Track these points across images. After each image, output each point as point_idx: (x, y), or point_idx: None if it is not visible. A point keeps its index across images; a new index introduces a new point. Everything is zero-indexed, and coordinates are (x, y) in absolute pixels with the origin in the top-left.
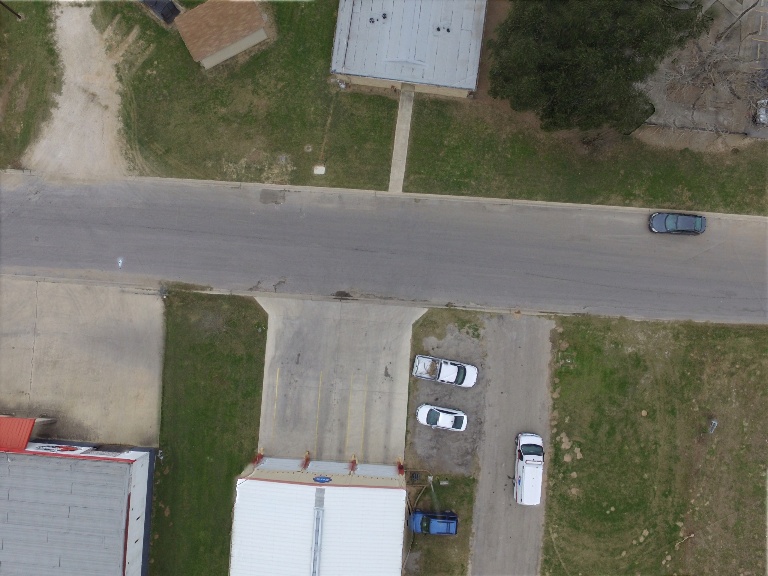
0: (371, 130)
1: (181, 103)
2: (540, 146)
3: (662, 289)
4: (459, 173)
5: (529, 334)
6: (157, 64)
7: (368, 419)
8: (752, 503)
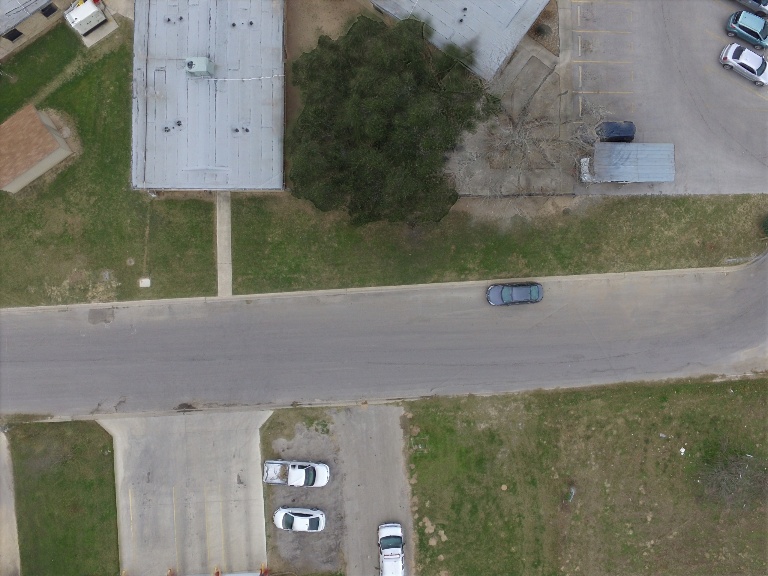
0: (191, 236)
1: None
2: (366, 231)
3: (508, 361)
4: (287, 269)
5: (379, 424)
6: None
7: (226, 529)
8: (622, 562)
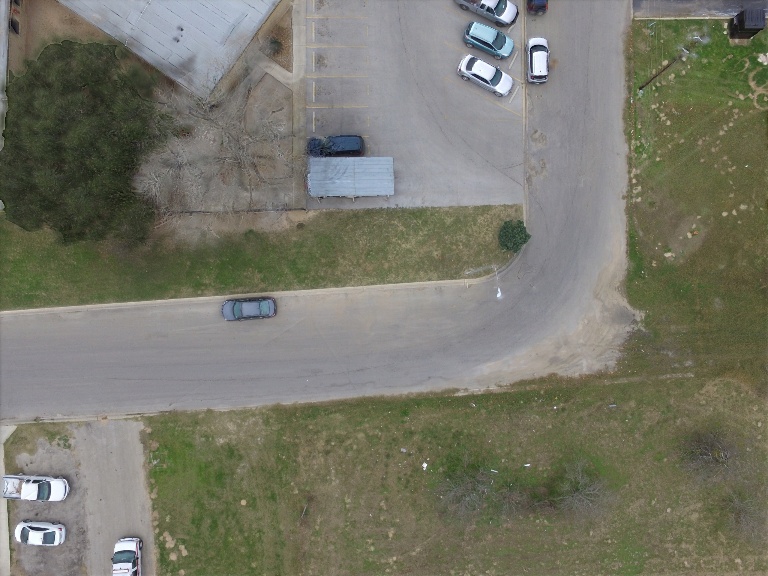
0: None
1: None
2: (103, 249)
3: (245, 376)
4: (29, 287)
5: (118, 438)
6: None
7: None
8: None
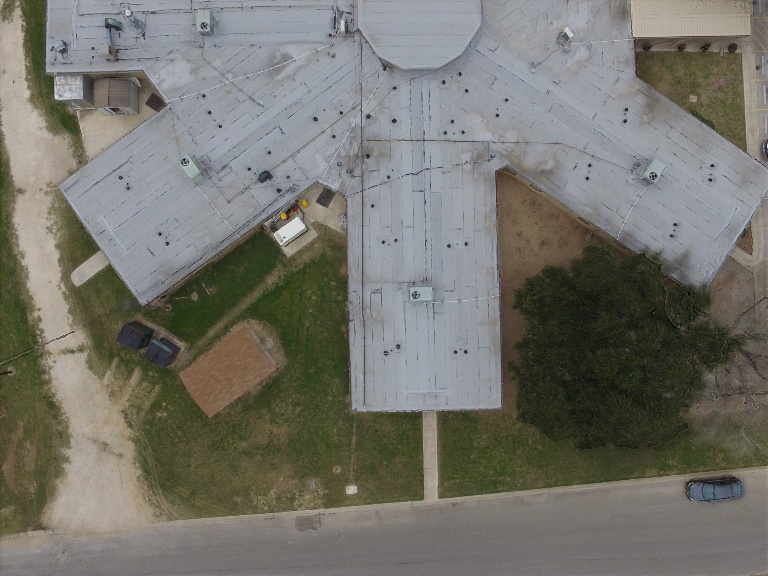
0: (398, 443)
1: (198, 443)
2: None
3: (706, 551)
4: (492, 472)
5: None
6: (166, 405)
7: None
8: None
